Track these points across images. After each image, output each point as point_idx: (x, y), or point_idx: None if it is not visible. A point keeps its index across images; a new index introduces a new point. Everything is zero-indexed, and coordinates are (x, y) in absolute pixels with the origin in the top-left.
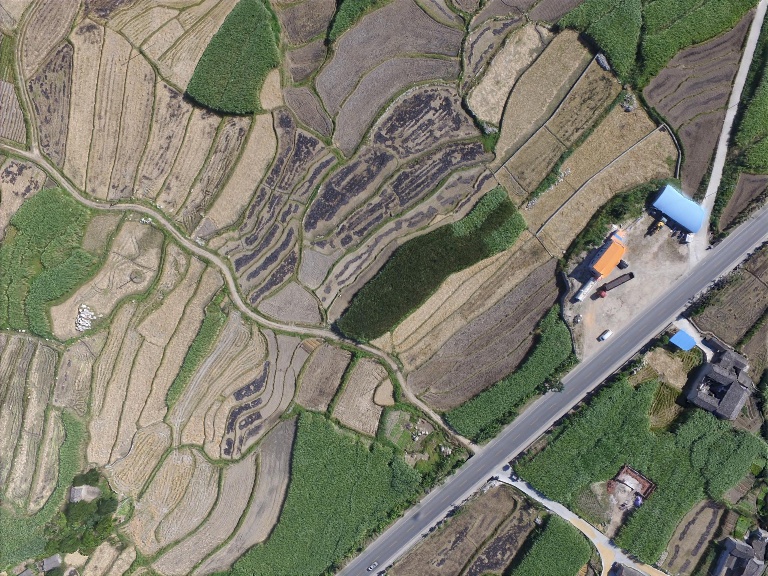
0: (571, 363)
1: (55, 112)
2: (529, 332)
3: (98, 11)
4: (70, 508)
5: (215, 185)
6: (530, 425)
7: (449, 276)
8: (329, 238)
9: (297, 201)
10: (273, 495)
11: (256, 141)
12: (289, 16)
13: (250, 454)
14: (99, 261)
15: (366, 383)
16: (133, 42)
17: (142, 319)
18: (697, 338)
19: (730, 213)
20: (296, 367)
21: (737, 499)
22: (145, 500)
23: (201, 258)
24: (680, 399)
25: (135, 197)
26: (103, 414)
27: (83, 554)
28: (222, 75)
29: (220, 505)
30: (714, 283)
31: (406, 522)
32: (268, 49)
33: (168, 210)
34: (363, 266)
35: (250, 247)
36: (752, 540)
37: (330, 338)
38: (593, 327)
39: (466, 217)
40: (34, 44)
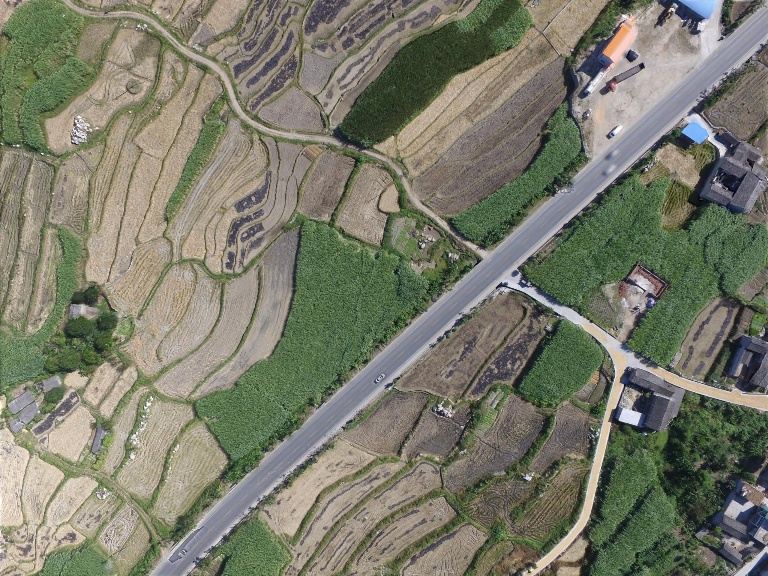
0: (581, 160)
1: None
2: (537, 134)
3: None
4: None
5: None
6: (539, 228)
7: (454, 77)
8: (330, 41)
9: (297, 3)
10: (277, 310)
11: None
12: None
13: (252, 268)
14: (94, 71)
15: (370, 190)
16: None
17: (139, 130)
18: (709, 134)
19: (742, 3)
20: (298, 176)
21: (752, 296)
22: (146, 318)
23: (199, 65)
24: (693, 197)
25: (130, 3)
26: (101, 231)
27: (83, 373)
28: None
29: (223, 321)
30: (726, 76)
31: (413, 331)
32: None
33: (164, 17)
34: (366, 69)
35: (249, 52)
36: (767, 336)
37: (333, 144)
38: (603, 124)
39: (471, 13)
40: None
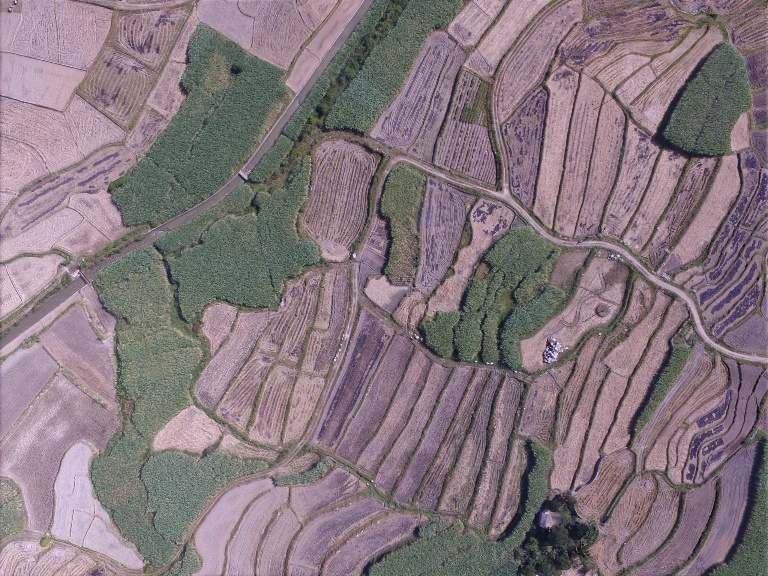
0: None
1: (527, 154)
2: None
3: (574, 58)
4: (543, 533)
5: (679, 223)
6: None
7: None
8: None
9: (760, 237)
10: (732, 517)
11: (721, 181)
12: (749, 62)
13: (711, 479)
14: (566, 296)
15: None
16: (606, 87)
17: (609, 351)
18: None
19: None
20: (758, 395)
21: None
22: (609, 524)
23: (668, 292)
24: None
25: (603, 235)
26: (567, 442)
27: None
28: (699, 119)
29: (681, 528)
30: None
31: None
32: (744, 95)
33: (634, 247)
34: None
35: (714, 281)
36: None
37: None
38: None
39: None
40: (510, 90)
